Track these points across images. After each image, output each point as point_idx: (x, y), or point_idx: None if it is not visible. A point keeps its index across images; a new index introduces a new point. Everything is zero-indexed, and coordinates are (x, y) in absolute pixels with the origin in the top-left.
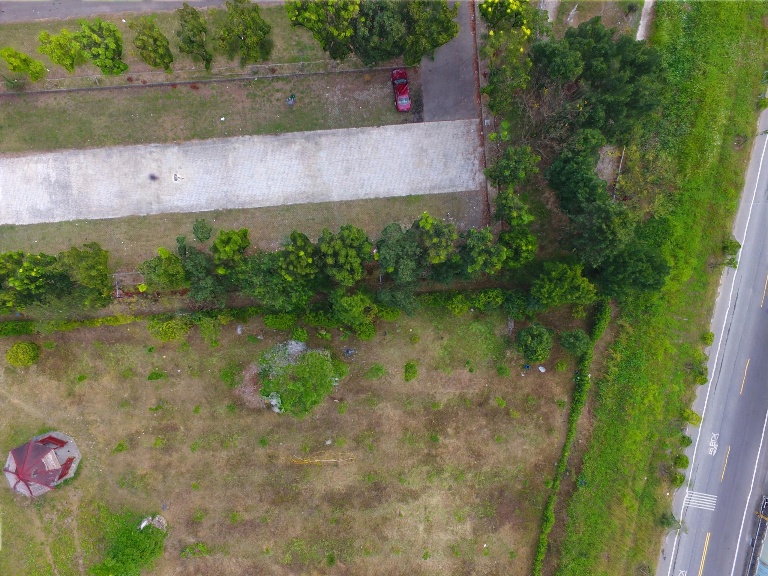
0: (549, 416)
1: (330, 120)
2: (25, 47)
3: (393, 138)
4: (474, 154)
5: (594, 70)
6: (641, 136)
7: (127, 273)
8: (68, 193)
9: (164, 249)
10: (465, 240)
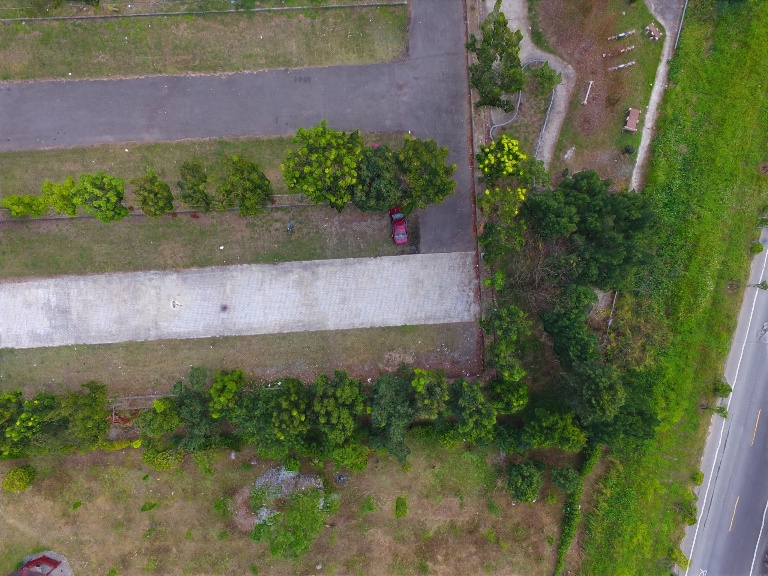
0: (539, 545)
1: (328, 250)
2: (29, 175)
3: (389, 269)
4: (469, 286)
5: (588, 225)
6: (635, 273)
7: (124, 398)
8: (68, 318)
9: (159, 402)
10: (459, 370)
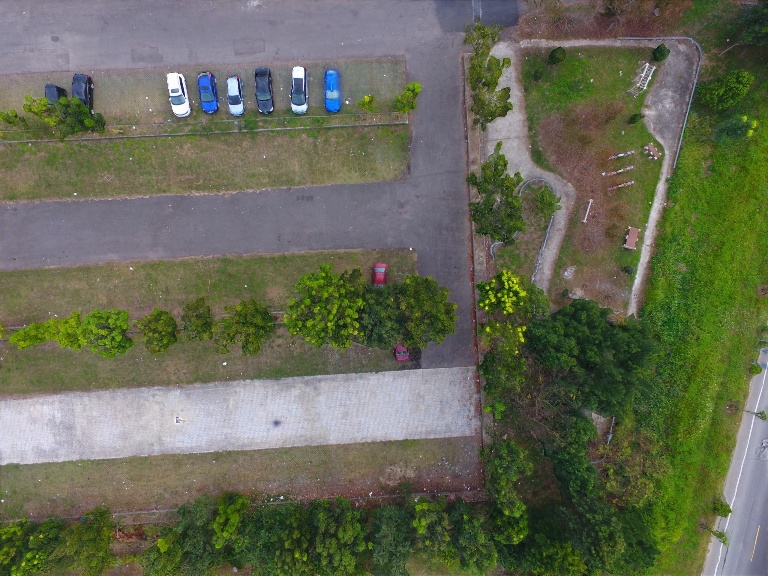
0: None
1: (330, 365)
2: (35, 293)
3: (391, 384)
4: (470, 401)
5: (588, 358)
6: None
7: (127, 513)
8: (72, 434)
9: (163, 541)
10: (459, 484)
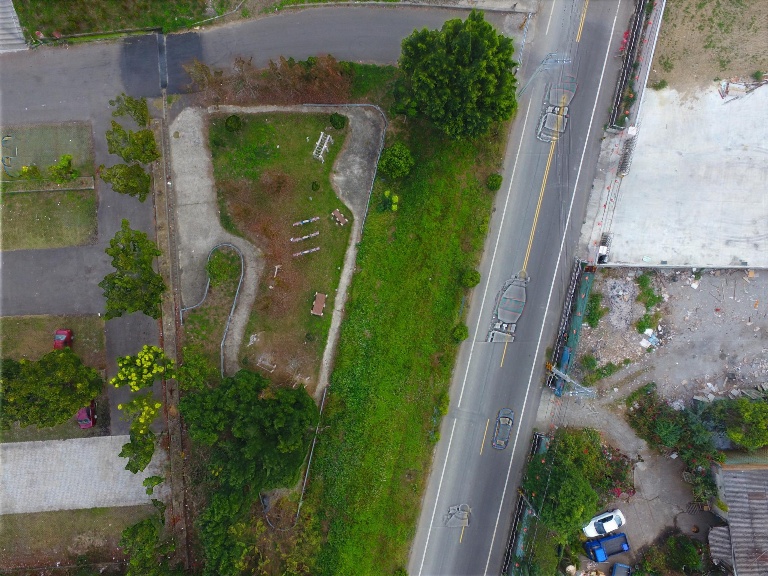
0: None
1: (16, 433)
2: None
3: (79, 451)
4: (161, 468)
5: None
6: (324, 456)
7: None
8: None
9: None
10: None
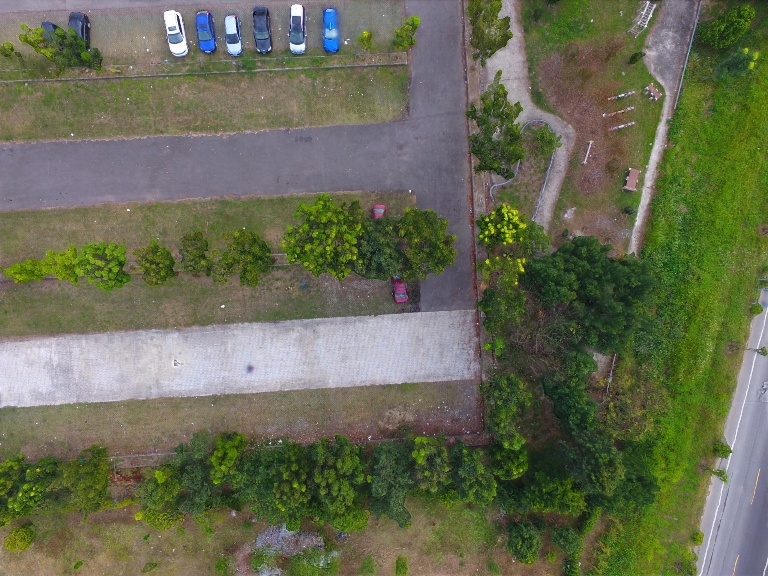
0: None
1: (328, 308)
2: (31, 235)
3: (390, 327)
4: (470, 344)
5: (588, 293)
6: (635, 332)
7: (125, 456)
8: (69, 377)
9: (161, 473)
10: (459, 428)
